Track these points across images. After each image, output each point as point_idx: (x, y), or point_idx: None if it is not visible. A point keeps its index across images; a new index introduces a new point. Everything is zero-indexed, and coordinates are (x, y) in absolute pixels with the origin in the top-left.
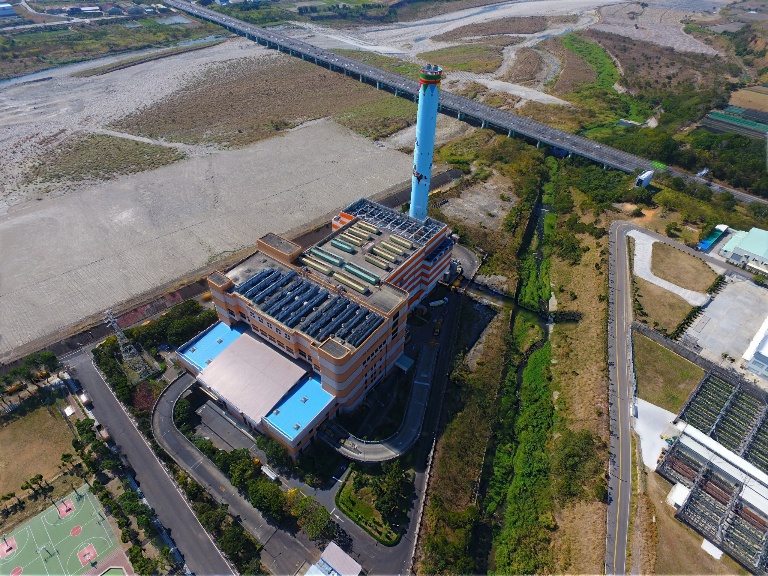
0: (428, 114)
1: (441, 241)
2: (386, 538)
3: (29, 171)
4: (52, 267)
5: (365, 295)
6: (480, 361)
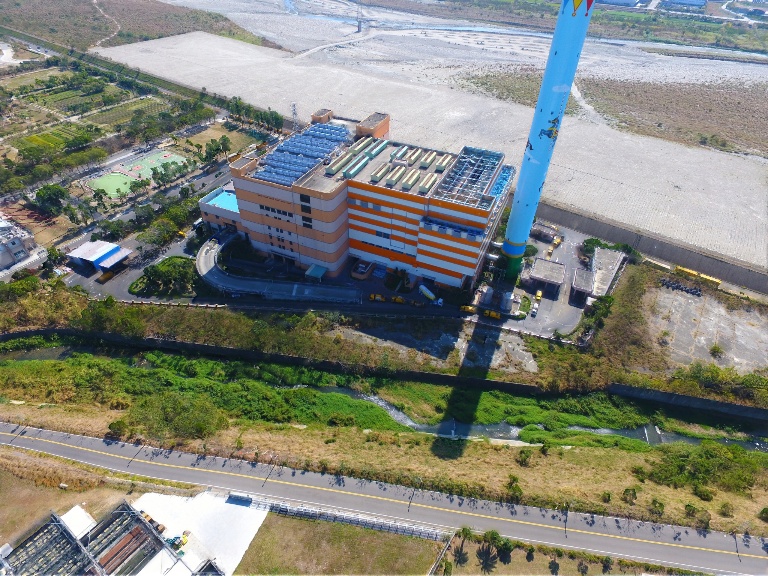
0: (555, 44)
1: (475, 227)
2: (136, 286)
3: (481, 76)
4: (380, 110)
5: (325, 174)
6: (338, 337)
